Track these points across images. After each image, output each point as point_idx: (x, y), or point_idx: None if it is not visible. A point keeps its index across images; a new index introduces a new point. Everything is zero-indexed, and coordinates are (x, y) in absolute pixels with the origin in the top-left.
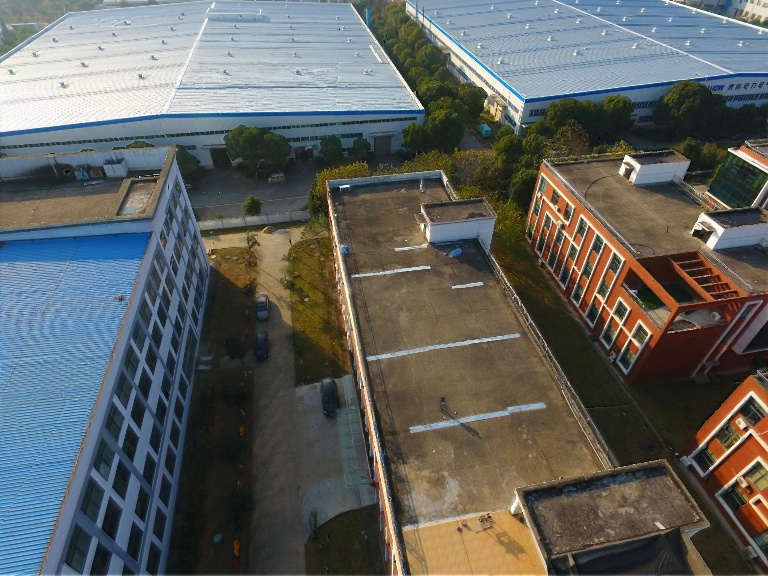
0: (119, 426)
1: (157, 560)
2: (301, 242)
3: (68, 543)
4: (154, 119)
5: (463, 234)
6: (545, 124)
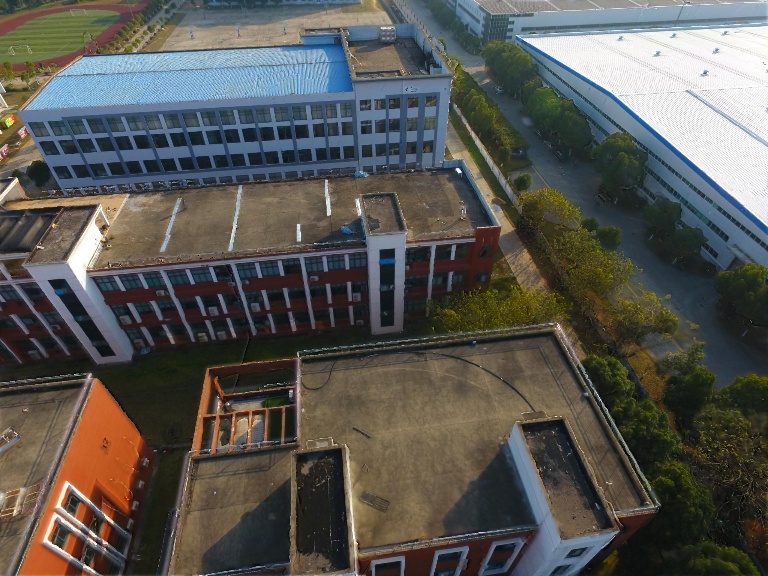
0: (230, 123)
1: None
2: None
3: (169, 113)
4: (605, 94)
5: None
6: None
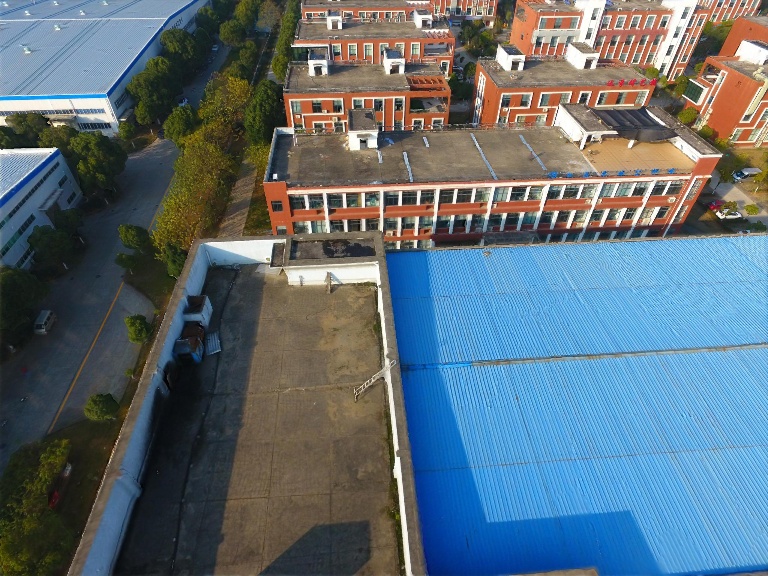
0: None
1: None
2: None
3: None
4: None
5: None
6: None
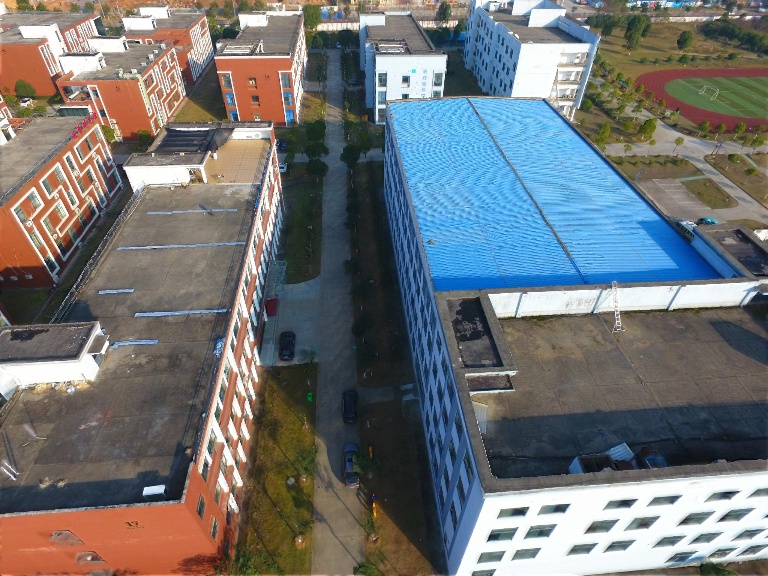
0: None
1: None
2: None
3: None
4: None
5: None
6: None
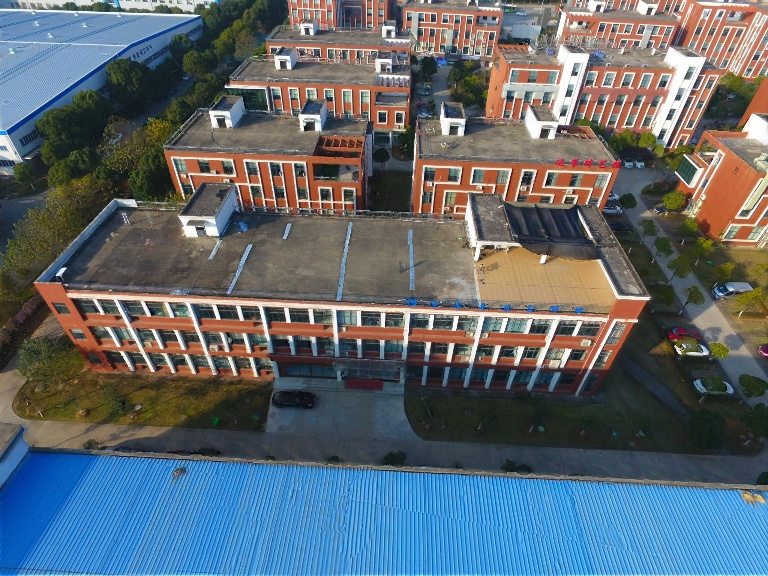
0: None
1: None
2: (16, 401)
3: None
4: None
5: (228, 213)
6: (53, 144)
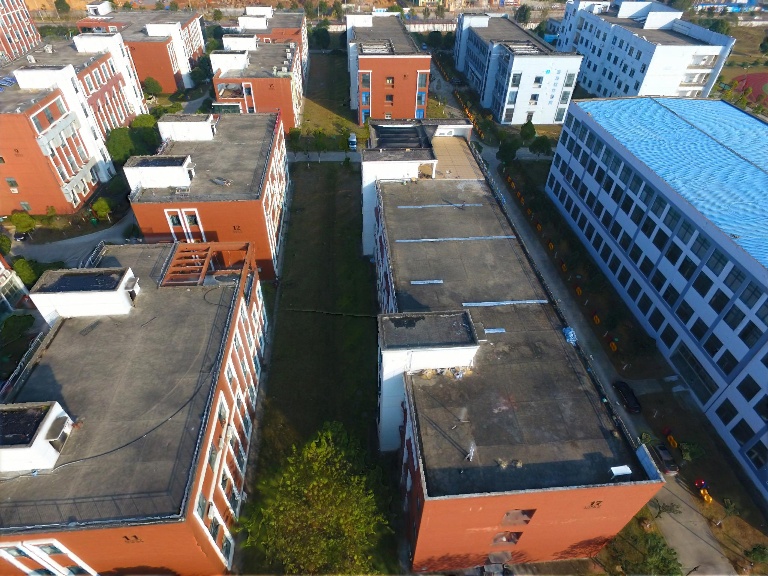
0: (657, 213)
1: (605, 259)
2: None
3: None
4: None
5: None
6: None
